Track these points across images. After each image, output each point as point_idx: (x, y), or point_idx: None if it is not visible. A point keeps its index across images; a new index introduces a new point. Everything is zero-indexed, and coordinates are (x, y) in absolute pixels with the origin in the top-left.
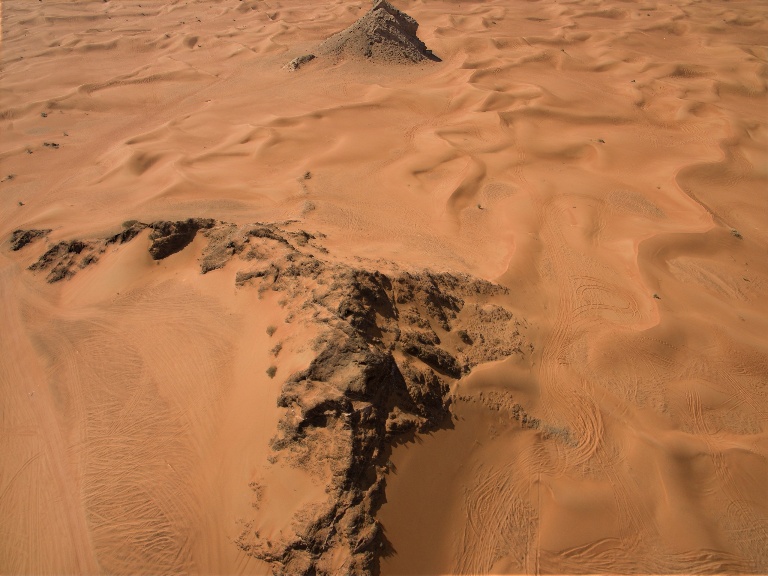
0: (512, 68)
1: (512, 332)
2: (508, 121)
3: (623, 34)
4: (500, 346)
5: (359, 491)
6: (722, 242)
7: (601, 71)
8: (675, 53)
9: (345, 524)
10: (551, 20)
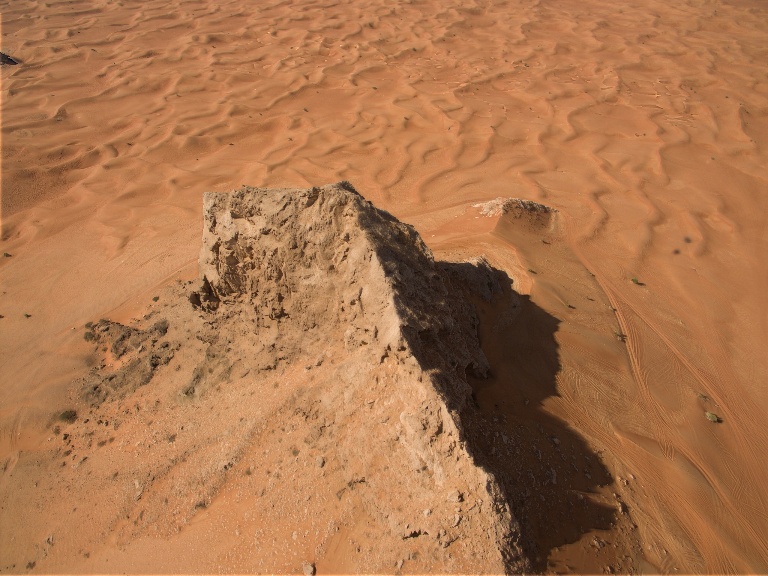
0: (53, 64)
1: None
2: (14, 93)
3: (144, 33)
4: None
5: None
6: (48, 123)
7: (112, 59)
8: (168, 42)
9: None
10: (128, 25)
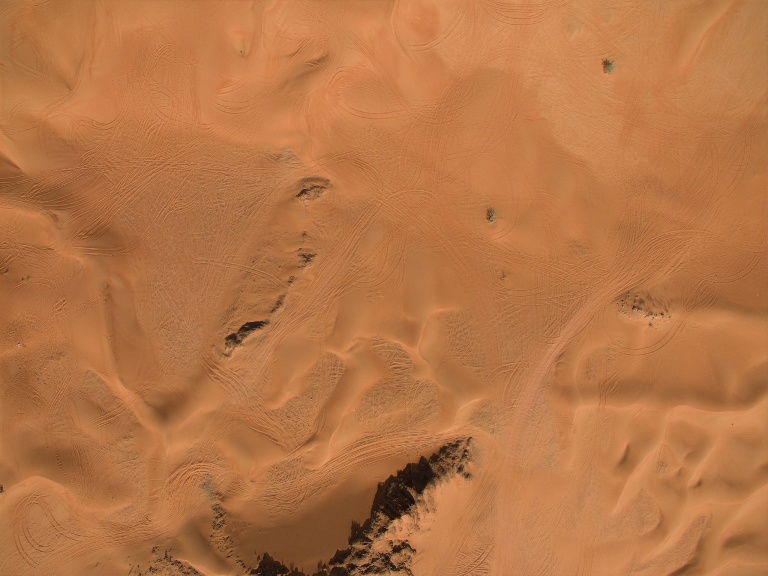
0: None
1: (154, 574)
2: None
3: None
4: (177, 573)
5: (348, 571)
6: None
7: None
8: None
9: (367, 560)
10: None
